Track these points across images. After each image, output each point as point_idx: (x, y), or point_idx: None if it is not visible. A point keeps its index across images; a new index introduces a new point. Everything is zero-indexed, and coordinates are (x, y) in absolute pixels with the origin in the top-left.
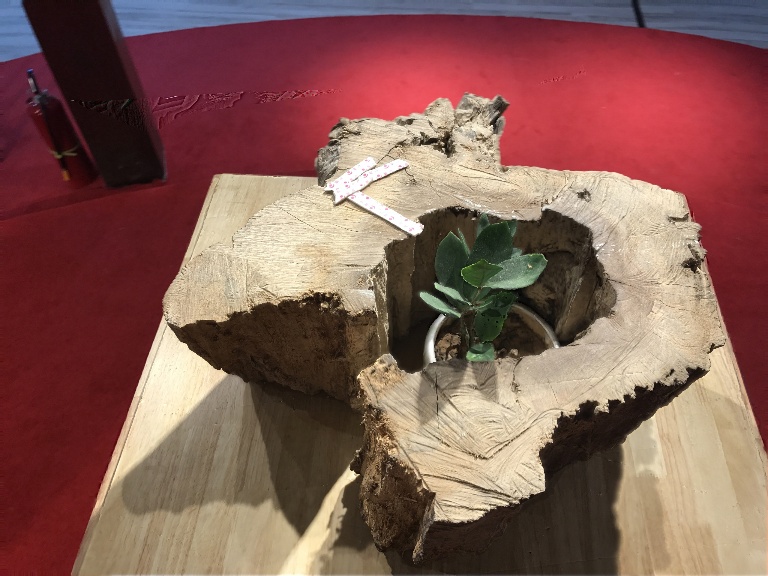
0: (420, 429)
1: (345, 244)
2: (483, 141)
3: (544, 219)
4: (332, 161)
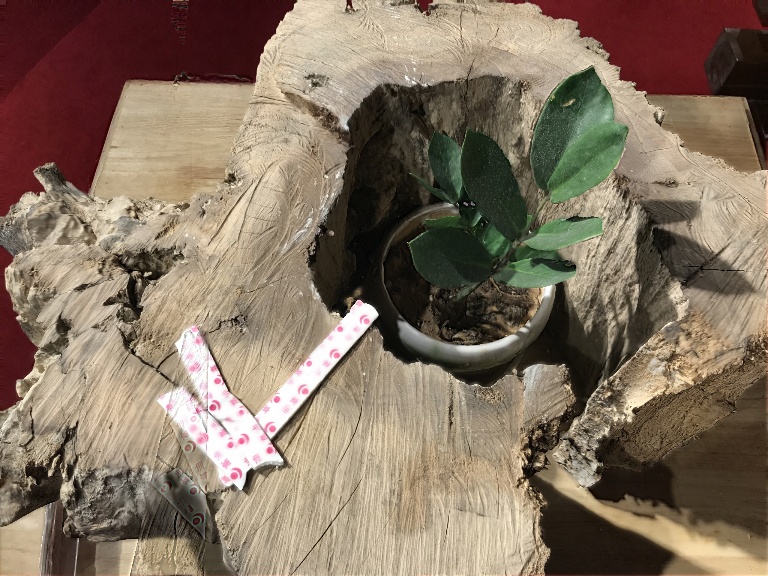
0: (761, 294)
1: (394, 435)
2: (138, 212)
3: (353, 136)
4: (133, 490)
